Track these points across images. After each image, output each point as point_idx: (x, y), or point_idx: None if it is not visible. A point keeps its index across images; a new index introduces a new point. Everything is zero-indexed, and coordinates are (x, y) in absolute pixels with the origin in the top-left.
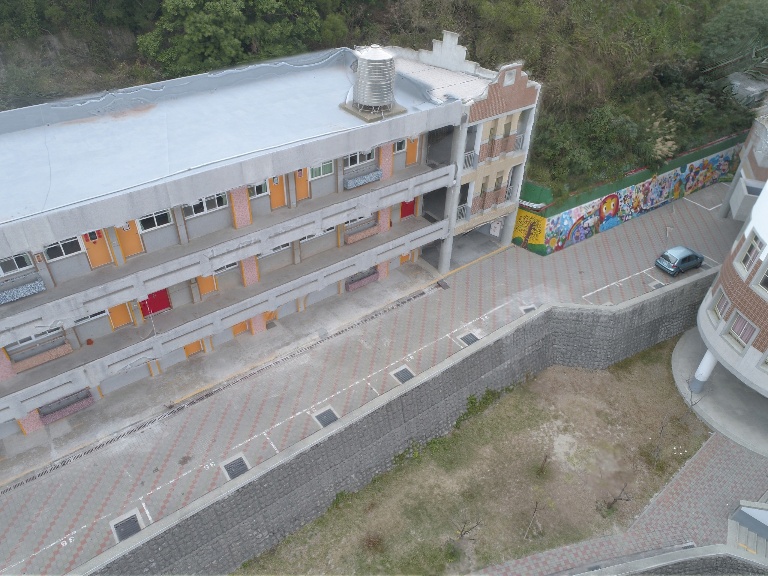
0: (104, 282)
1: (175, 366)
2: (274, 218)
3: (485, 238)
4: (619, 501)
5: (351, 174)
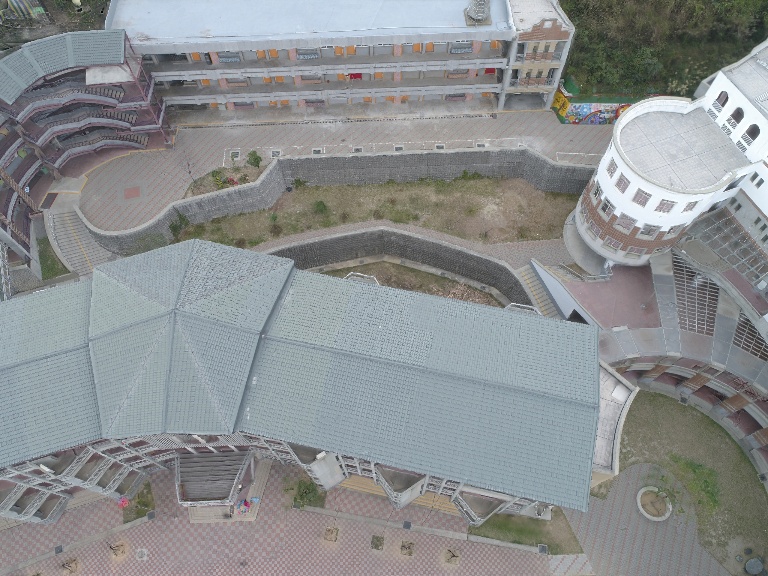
0: (335, 63)
1: (358, 103)
2: (412, 56)
3: (540, 100)
4: (492, 236)
5: (456, 46)
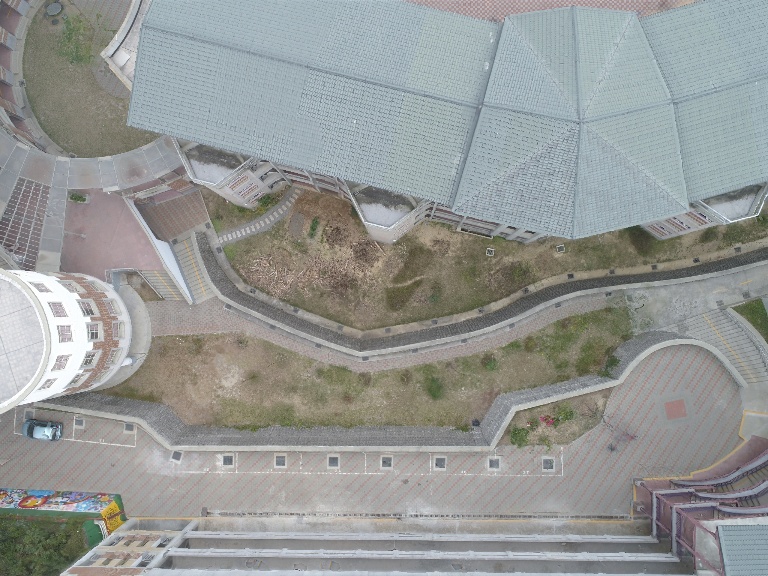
0: (410, 566)
1: None
2: None
3: None
4: None
5: None
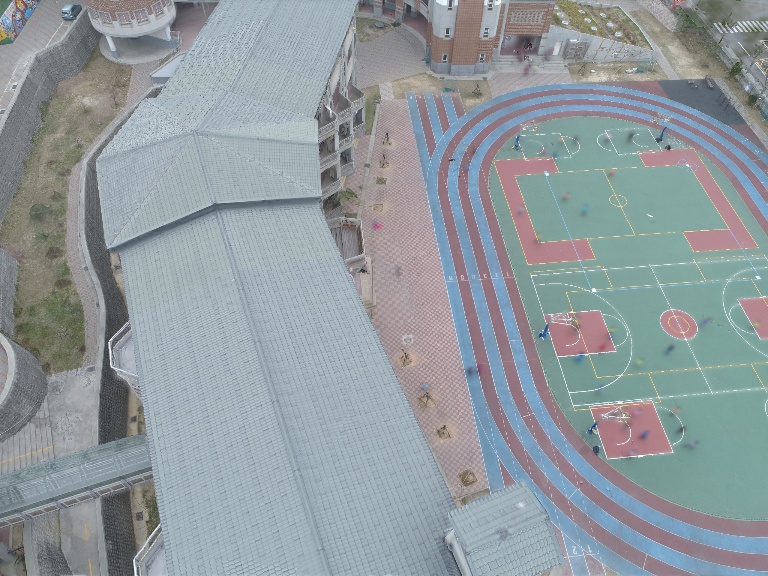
0: None
1: None
2: None
3: None
4: (118, 102)
5: None
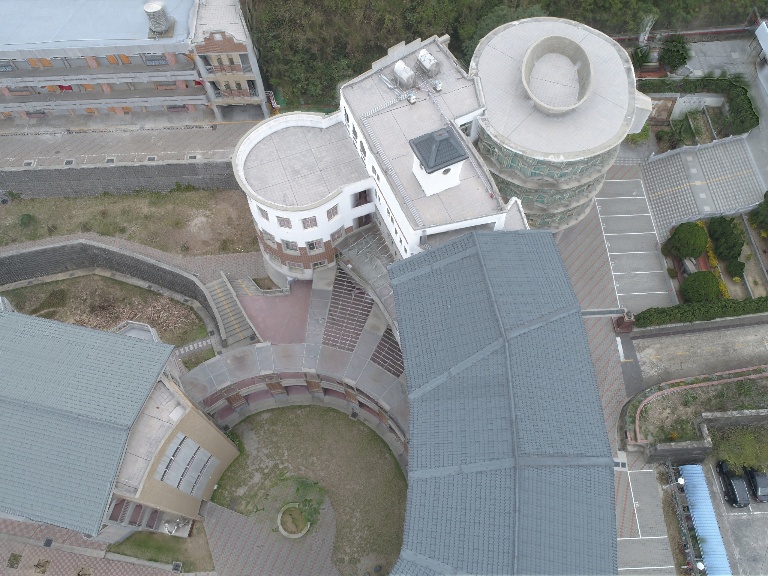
0: None
1: (81, 115)
2: (108, 68)
3: None
4: (193, 249)
5: (151, 58)
